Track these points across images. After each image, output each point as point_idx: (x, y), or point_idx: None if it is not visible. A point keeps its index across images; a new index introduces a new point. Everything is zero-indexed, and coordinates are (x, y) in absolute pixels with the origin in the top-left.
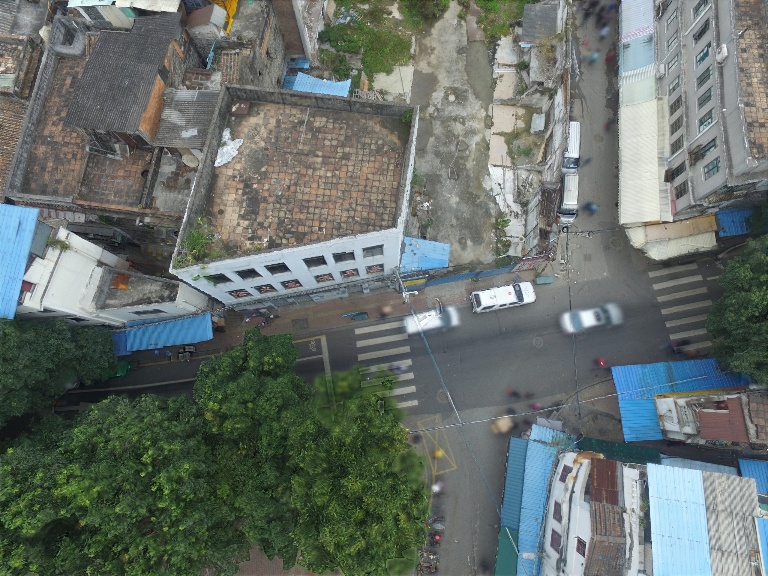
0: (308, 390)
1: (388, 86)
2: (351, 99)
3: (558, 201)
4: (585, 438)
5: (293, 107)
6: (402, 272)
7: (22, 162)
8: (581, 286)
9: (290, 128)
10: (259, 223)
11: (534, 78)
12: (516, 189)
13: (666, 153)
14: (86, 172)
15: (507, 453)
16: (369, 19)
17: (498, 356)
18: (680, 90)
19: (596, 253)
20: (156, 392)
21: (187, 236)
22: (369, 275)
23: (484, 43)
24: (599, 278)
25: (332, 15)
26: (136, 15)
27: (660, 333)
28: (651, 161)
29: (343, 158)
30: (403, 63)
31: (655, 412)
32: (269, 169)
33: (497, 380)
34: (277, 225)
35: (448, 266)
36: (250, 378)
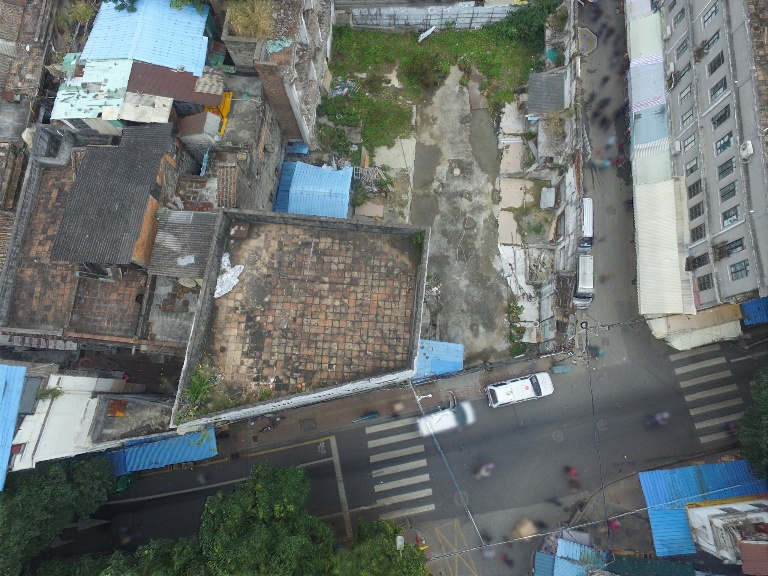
0: (322, 530)
1: (390, 161)
2: (358, 222)
3: (574, 288)
4: (615, 556)
5: (296, 227)
6: (415, 379)
7: (7, 289)
8: (600, 373)
9: (293, 251)
10: (264, 361)
11: (543, 154)
12: (528, 270)
13: (686, 239)
14: (76, 299)
15: (532, 569)
16: (367, 89)
17: (517, 453)
18: (699, 174)
19: (614, 336)
20: (159, 504)
21: (188, 383)
22: (380, 384)
23: (488, 111)
24: (618, 363)
25: (329, 87)
26: (124, 125)
27: (685, 422)
28: (670, 247)
29: (351, 284)
30: (404, 135)
31: (687, 523)
32: (273, 299)
33: (517, 479)
34: (284, 363)
35: (463, 369)
36: (260, 530)
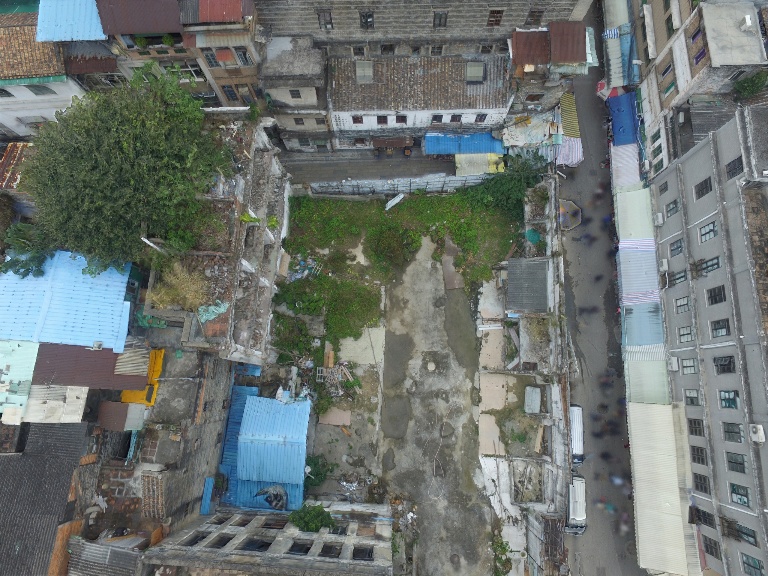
0: None
1: (357, 355)
2: (304, 575)
3: (564, 528)
4: None
5: None
6: None
7: None
8: None
9: None
10: None
11: (525, 359)
12: (513, 490)
13: (688, 482)
14: None
15: None
16: (330, 268)
17: None
18: (701, 415)
19: (610, 565)
20: None
21: None
22: None
23: (464, 291)
24: None
25: (287, 270)
26: None
27: None
28: (671, 489)
29: None
30: (372, 323)
31: None
32: None
33: None
34: None
35: None
36: None
